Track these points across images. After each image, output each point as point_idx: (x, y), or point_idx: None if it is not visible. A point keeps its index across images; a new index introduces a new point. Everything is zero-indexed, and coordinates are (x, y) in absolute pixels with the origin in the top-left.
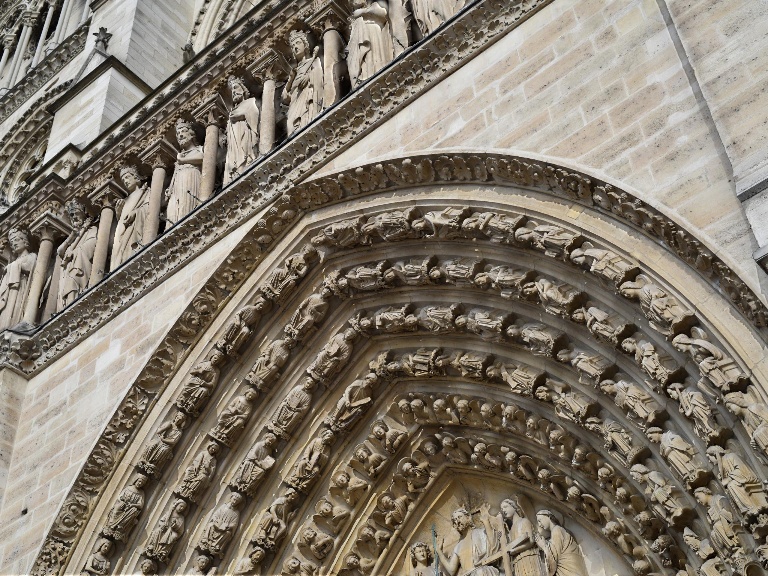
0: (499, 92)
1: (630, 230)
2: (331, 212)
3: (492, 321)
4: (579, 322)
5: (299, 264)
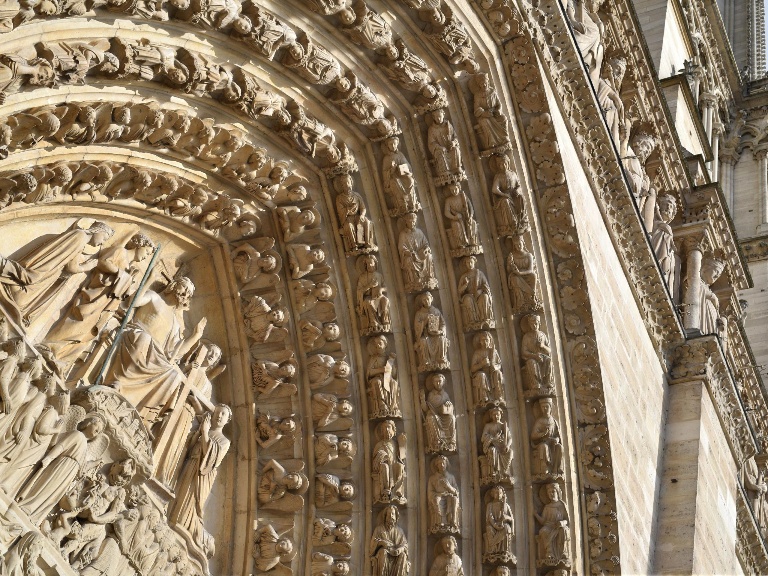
0: None
1: None
2: None
3: None
4: None
5: None
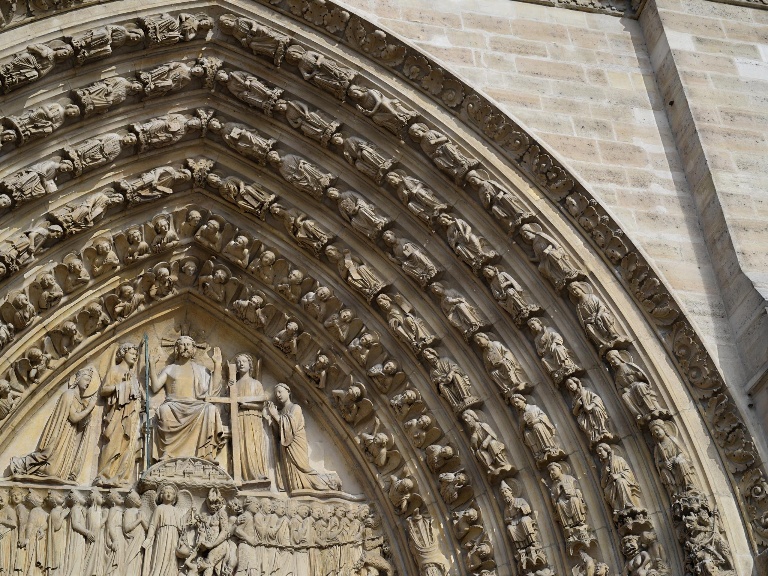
0: (490, 44)
1: (586, 242)
2: (253, 7)
3: (375, 216)
4: (478, 274)
5: (192, 27)
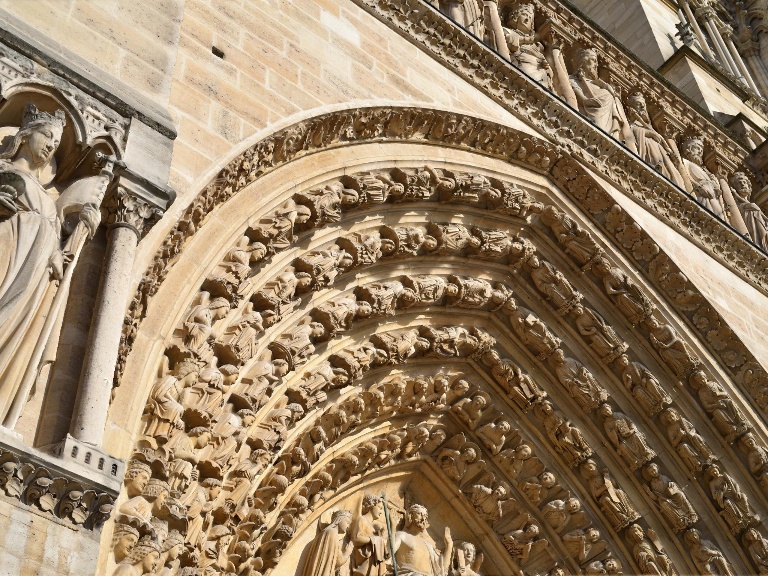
0: None
1: None
2: None
3: None
4: None
5: None
